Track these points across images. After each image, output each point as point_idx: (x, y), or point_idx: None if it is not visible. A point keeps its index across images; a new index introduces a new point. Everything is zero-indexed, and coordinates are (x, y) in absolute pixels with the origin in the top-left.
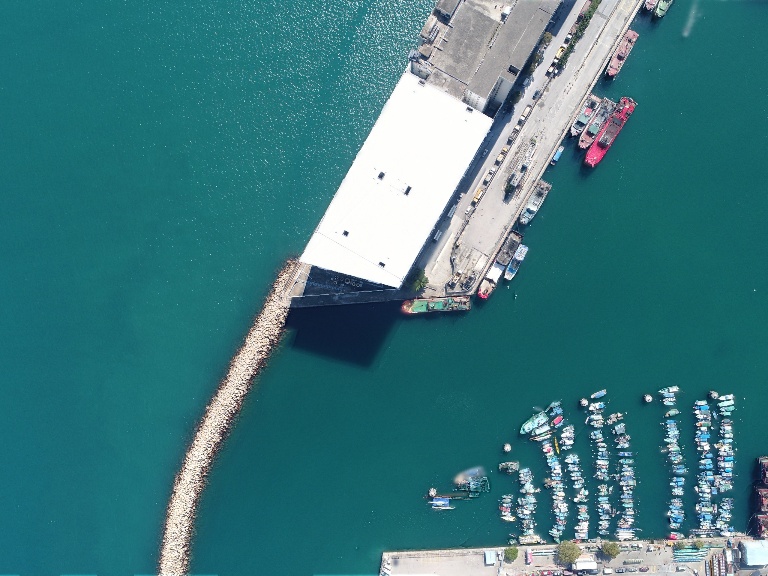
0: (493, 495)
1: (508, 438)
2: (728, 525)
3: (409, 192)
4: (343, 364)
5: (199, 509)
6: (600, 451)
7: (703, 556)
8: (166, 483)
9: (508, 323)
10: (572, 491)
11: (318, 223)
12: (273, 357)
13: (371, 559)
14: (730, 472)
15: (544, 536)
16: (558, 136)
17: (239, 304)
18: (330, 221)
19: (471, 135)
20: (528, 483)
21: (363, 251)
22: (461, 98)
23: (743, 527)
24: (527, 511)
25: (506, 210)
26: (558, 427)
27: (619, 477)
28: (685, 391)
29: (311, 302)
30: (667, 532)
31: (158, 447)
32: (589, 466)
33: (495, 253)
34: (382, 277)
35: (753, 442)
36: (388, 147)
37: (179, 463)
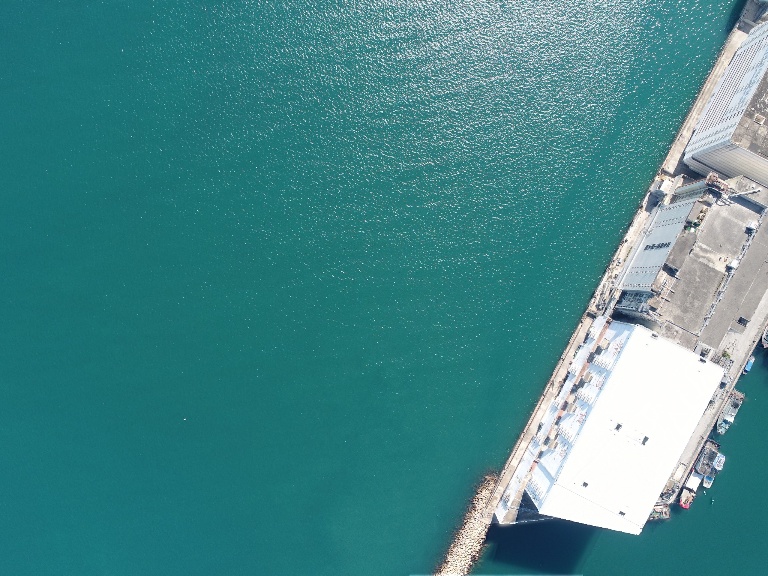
0: None
1: None
2: None
3: (646, 442)
4: (545, 575)
5: None
6: None
7: None
8: None
9: None
10: None
11: (516, 439)
12: (473, 571)
13: None
14: None
15: None
16: (749, 347)
17: (438, 521)
18: (569, 473)
19: (705, 386)
20: None
21: (602, 500)
22: (693, 349)
23: None
24: None
25: (702, 420)
26: None
27: None
28: None
29: None
30: None
31: None
32: None
33: (693, 462)
34: (622, 525)
35: None
36: (624, 399)
37: None
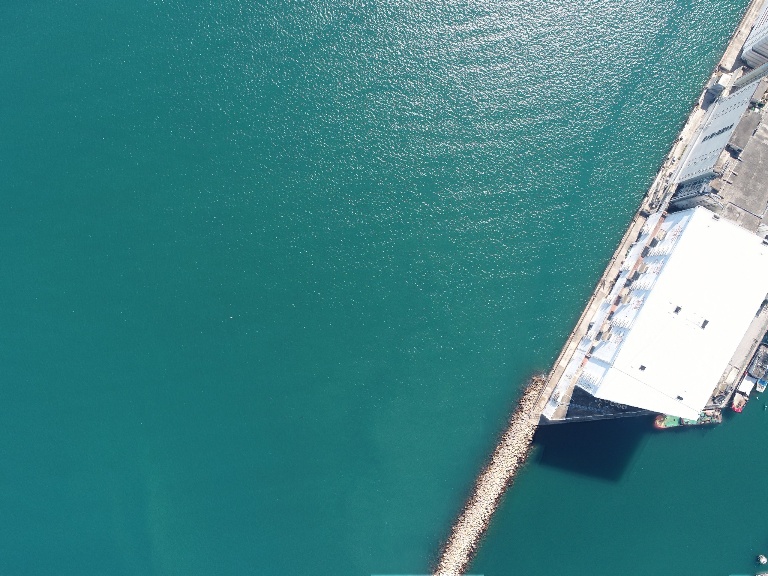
0: None
1: (762, 549)
2: None
3: (706, 326)
4: (592, 480)
5: None
6: None
7: None
8: None
9: (759, 434)
10: None
11: (565, 339)
12: (519, 474)
13: None
14: None
15: None
16: None
17: (484, 422)
18: (626, 356)
19: (767, 268)
20: None
21: (659, 385)
22: None
23: None
24: None
25: (756, 323)
26: None
27: None
28: None
29: None
30: None
31: (403, 570)
32: None
33: (746, 366)
34: (679, 410)
35: None
36: (683, 281)
37: None
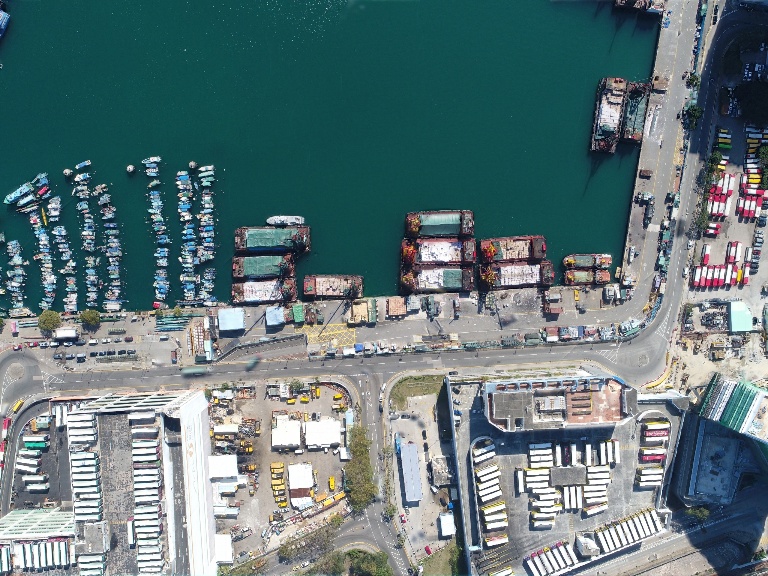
0: None
1: None
2: (212, 296)
3: None
4: None
5: None
6: (86, 222)
7: (184, 325)
8: None
9: None
10: (61, 263)
11: None
12: None
13: None
14: (211, 242)
15: (35, 309)
16: None
17: None
18: None
19: None
20: (17, 255)
21: None
22: None
23: (226, 298)
24: (15, 283)
25: None
26: (45, 198)
27: (105, 248)
28: (169, 163)
29: None
30: (152, 303)
31: None
32: (77, 238)
33: None
34: None
35: (234, 213)
36: None
37: None
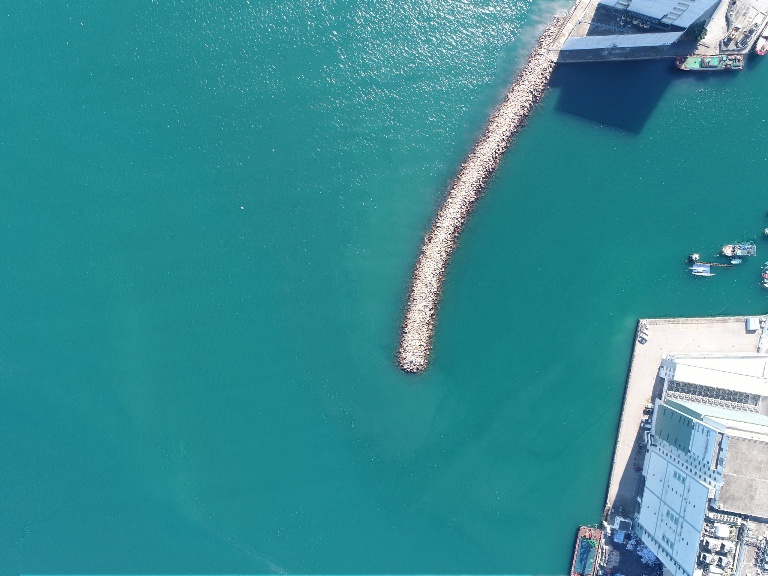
0: (756, 262)
1: None
2: None
3: None
4: (607, 124)
5: (447, 272)
6: None
7: None
8: (414, 244)
9: None
10: None
11: None
12: (533, 116)
13: (626, 326)
14: None
15: None
16: None
17: (501, 59)
18: None
19: None
20: None
21: None
22: None
23: None
24: None
25: None
26: None
27: None
28: None
29: (579, 57)
30: None
31: (409, 205)
32: None
33: None
34: None
35: None
36: None
37: (429, 223)
